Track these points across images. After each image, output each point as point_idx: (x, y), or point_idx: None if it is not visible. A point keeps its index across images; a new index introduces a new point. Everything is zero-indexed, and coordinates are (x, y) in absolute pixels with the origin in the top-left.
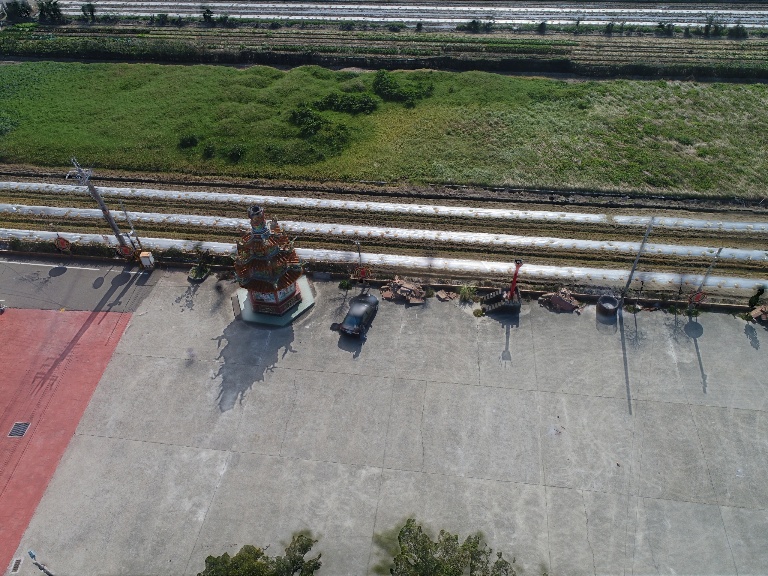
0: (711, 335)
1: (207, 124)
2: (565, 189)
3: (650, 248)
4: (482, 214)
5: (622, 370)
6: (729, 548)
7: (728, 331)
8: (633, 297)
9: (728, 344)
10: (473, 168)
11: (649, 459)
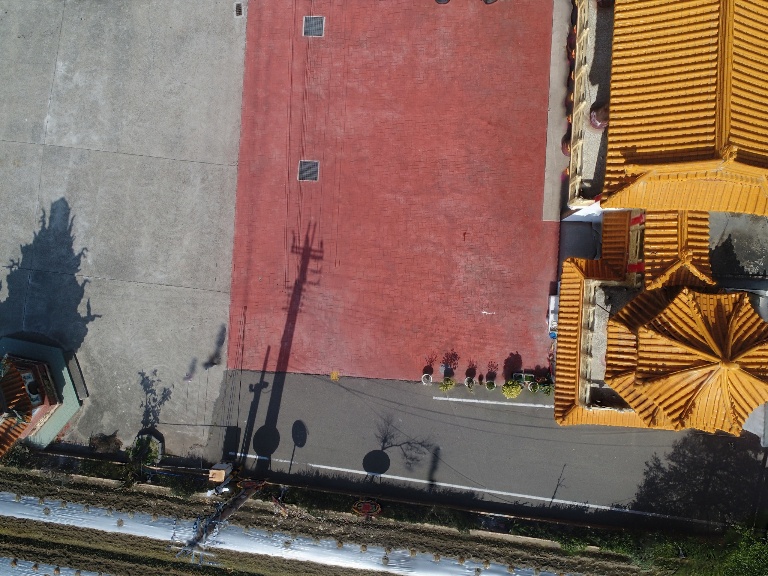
0: None
1: None
2: None
3: None
4: None
5: None
6: None
7: None
8: None
9: None
10: None
11: None
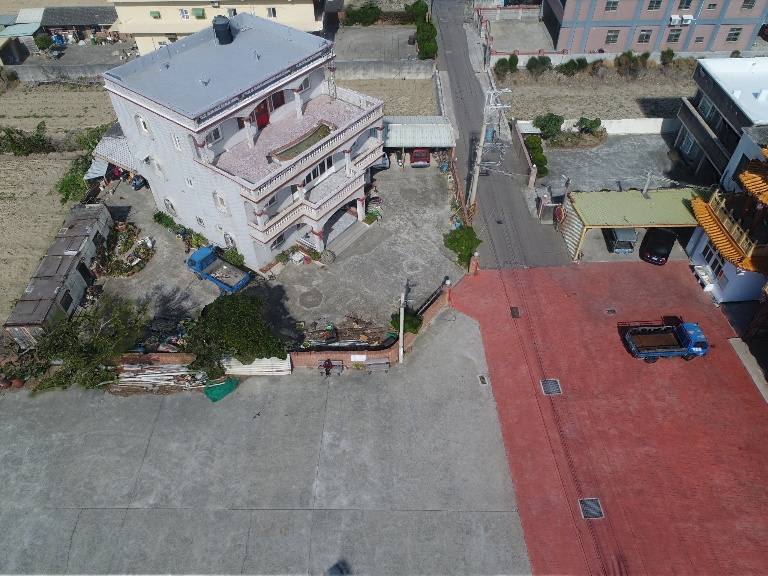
0: None
1: None
2: None
3: None
4: None
5: None
6: None
7: None
8: None
9: None
10: None
11: None
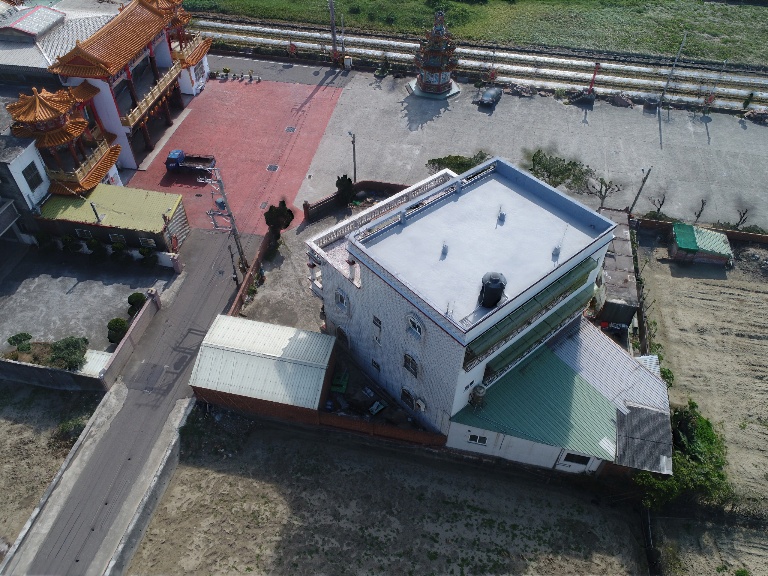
0: (717, 122)
1: (366, 2)
2: (625, 53)
3: (682, 85)
4: (567, 62)
5: (658, 132)
6: (713, 199)
7: (728, 121)
8: (668, 101)
9: (727, 126)
10: (560, 38)
11: (671, 166)
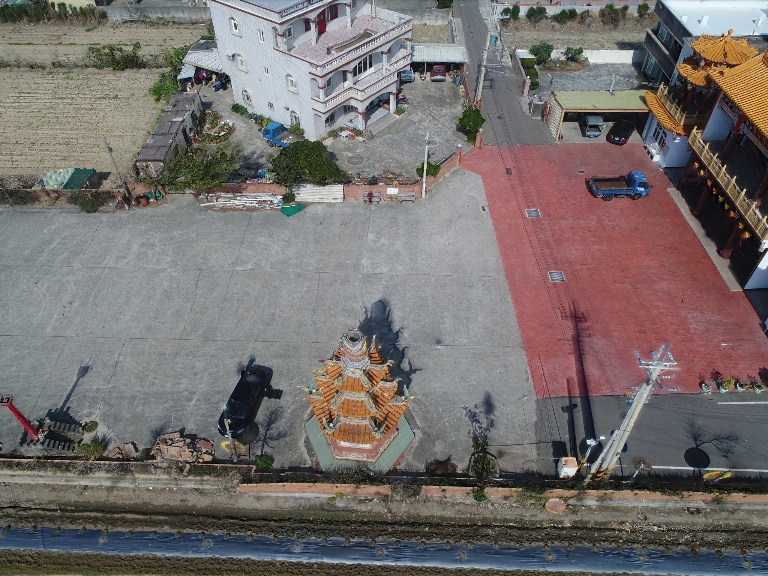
0: None
1: None
2: None
3: None
4: None
5: None
6: None
7: None
8: None
9: None
10: None
11: (6, 289)
